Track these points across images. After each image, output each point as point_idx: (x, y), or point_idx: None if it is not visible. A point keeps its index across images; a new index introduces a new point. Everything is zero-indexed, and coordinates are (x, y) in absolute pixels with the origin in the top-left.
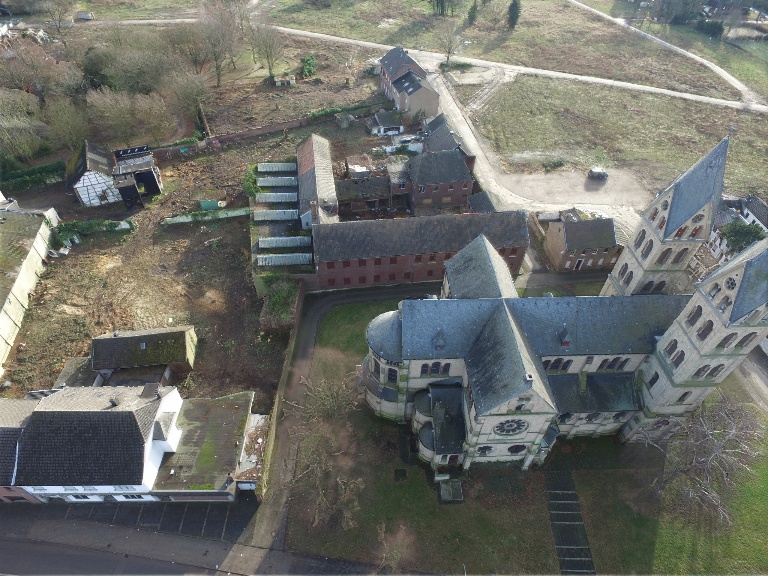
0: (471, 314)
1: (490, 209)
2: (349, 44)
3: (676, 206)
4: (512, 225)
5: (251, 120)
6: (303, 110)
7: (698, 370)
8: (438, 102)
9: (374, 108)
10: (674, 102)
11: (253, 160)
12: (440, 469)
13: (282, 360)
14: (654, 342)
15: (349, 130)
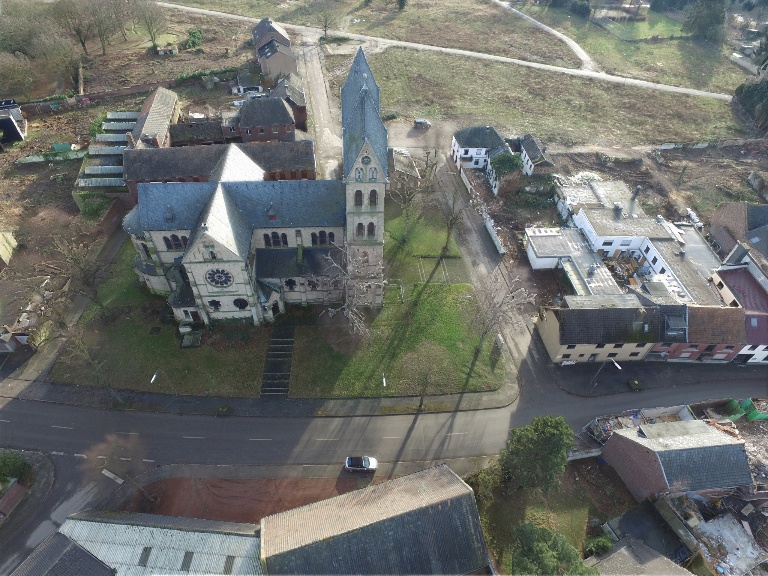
0: (195, 194)
1: None
2: (242, 21)
3: (345, 106)
4: (301, 152)
5: (125, 82)
6: (177, 74)
7: (359, 230)
8: (296, 66)
9: (241, 72)
10: (519, 69)
11: None
12: (187, 325)
13: None
14: (345, 217)
15: (213, 90)
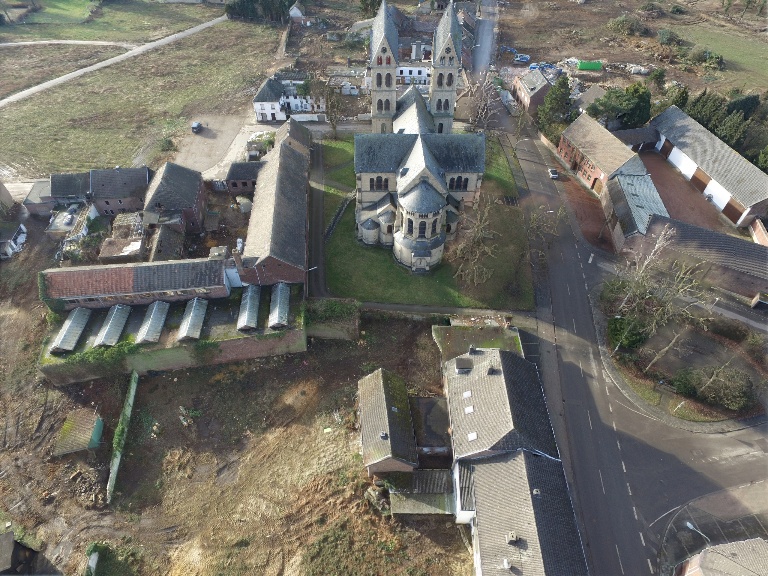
0: (427, 150)
1: (259, 165)
2: None
3: (390, 45)
4: (291, 154)
5: None
6: None
7: None
8: (1, 183)
9: None
10: (107, 72)
11: None
12: None
13: (388, 323)
14: None
15: None
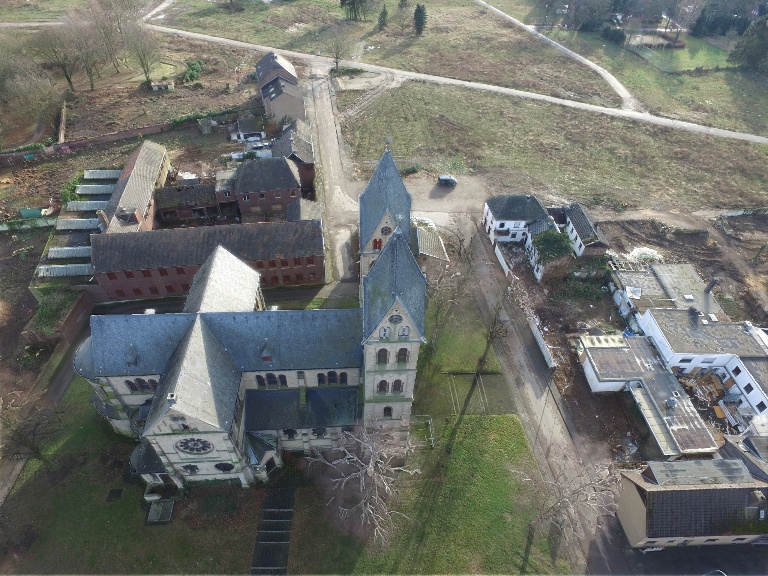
0: (165, 329)
1: (297, 218)
2: (246, 48)
3: (364, 218)
4: (306, 234)
5: (112, 125)
6: (171, 115)
7: (381, 385)
8: (304, 108)
9: (242, 114)
10: (552, 109)
11: (99, 166)
12: (155, 488)
13: None
14: (362, 356)
15: (210, 136)
